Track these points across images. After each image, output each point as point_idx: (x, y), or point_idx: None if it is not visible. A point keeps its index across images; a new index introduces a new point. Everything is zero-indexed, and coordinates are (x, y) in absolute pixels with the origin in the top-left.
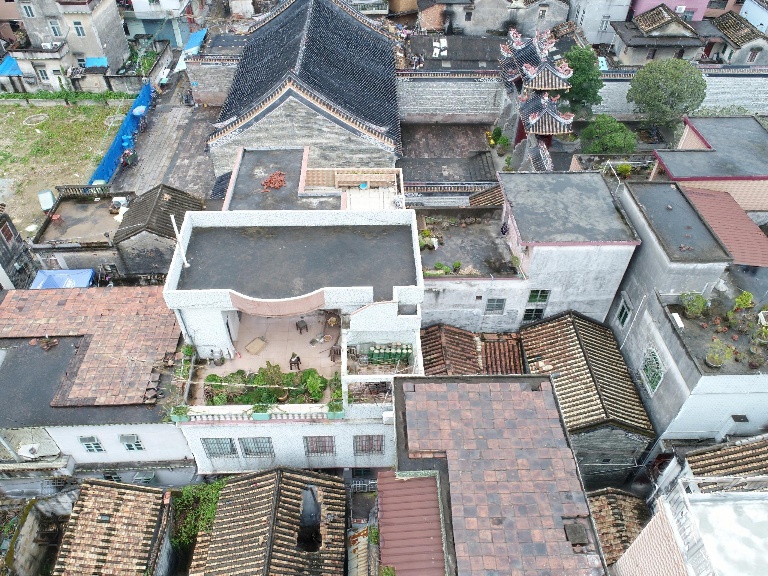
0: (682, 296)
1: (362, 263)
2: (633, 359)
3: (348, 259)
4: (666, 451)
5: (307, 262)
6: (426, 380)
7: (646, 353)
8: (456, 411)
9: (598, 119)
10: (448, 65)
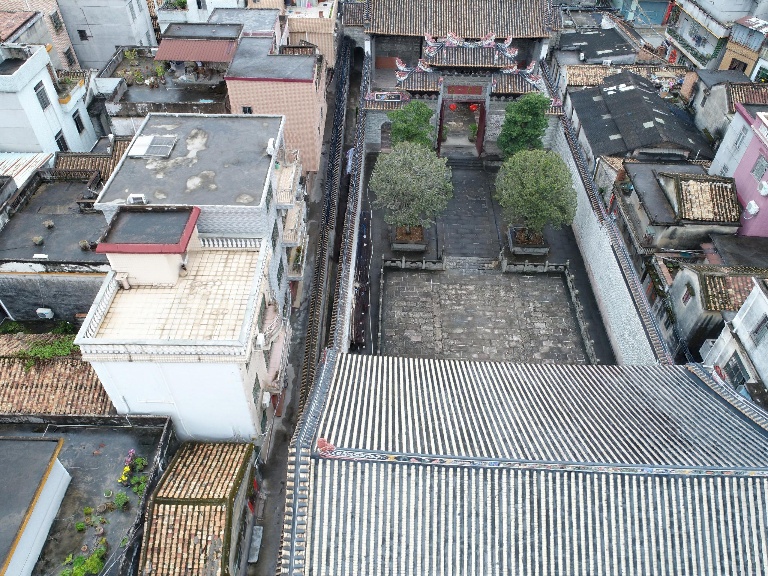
0: None
1: None
2: None
3: None
4: None
5: None
6: None
7: None
8: None
9: None
10: (596, 100)
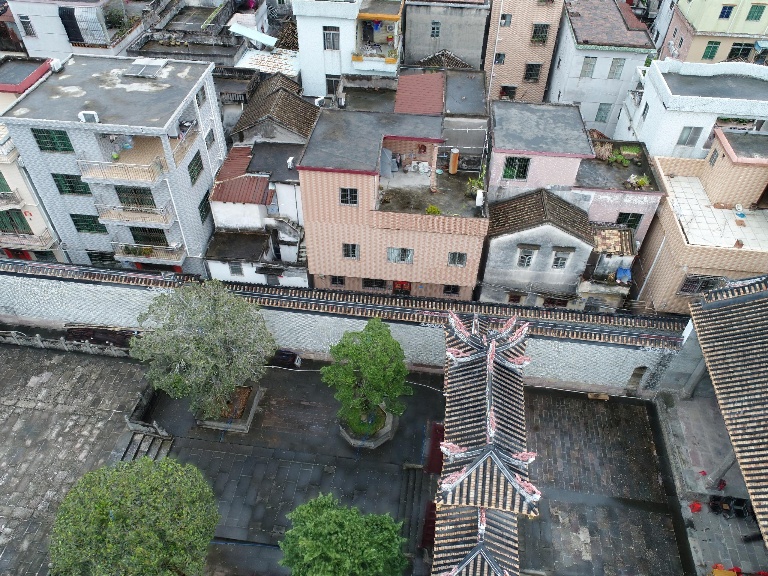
0: None
1: (695, 90)
2: None
3: (706, 92)
4: None
5: (734, 93)
6: None
7: None
8: None
9: (393, 347)
10: None
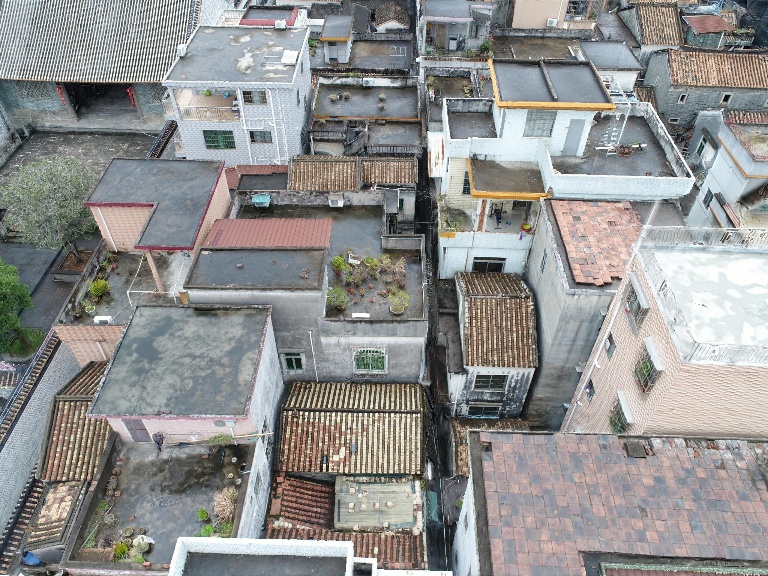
0: (328, 303)
1: None
2: (340, 374)
3: None
4: (432, 383)
5: None
6: (482, 563)
7: (358, 358)
8: (527, 532)
9: None
10: None
